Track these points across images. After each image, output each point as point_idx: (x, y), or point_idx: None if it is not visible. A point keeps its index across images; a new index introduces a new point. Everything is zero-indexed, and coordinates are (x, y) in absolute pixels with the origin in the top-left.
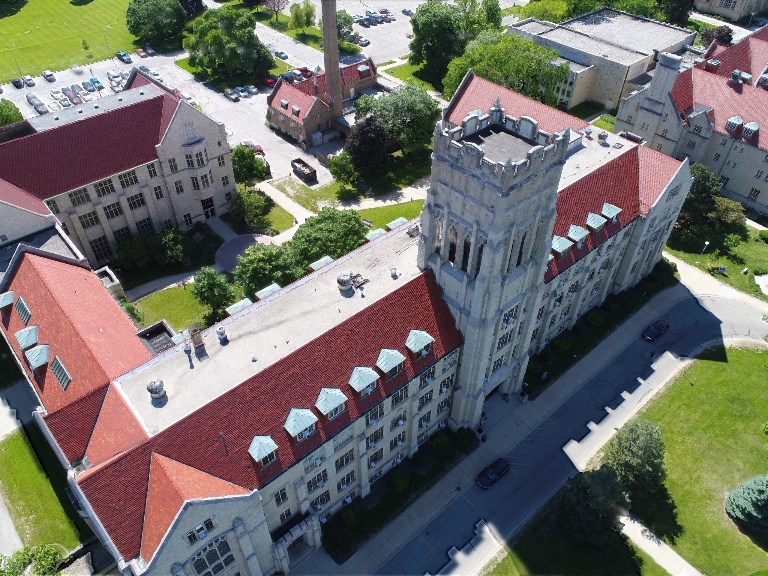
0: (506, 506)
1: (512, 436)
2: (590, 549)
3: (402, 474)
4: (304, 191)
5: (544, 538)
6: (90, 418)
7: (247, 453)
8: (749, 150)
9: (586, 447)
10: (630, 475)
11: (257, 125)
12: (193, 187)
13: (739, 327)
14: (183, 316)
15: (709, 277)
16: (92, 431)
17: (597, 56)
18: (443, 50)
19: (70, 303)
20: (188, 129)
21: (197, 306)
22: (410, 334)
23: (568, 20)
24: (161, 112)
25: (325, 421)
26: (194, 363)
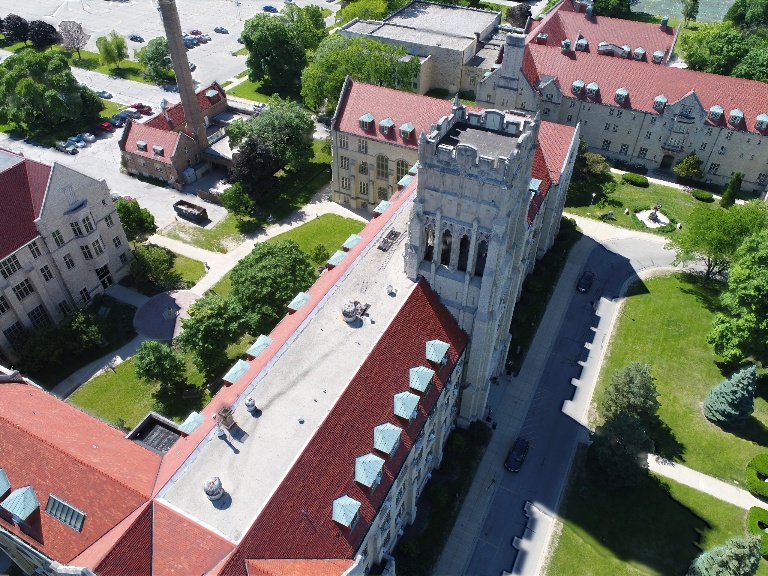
0: (541, 481)
1: (516, 415)
2: (625, 492)
3: (439, 487)
4: (200, 233)
5: (585, 497)
6: (144, 550)
7: (332, 522)
8: (595, 107)
9: (580, 403)
10: (634, 414)
11: (112, 174)
12: (84, 257)
13: (644, 260)
14: (128, 403)
15: (603, 224)
16: (151, 564)
17: (432, 46)
18: (285, 62)
19: (40, 428)
20: (67, 194)
21: (139, 387)
22: (427, 346)
23: (388, 16)
24: (27, 181)
25: (388, 460)
26: (236, 447)
